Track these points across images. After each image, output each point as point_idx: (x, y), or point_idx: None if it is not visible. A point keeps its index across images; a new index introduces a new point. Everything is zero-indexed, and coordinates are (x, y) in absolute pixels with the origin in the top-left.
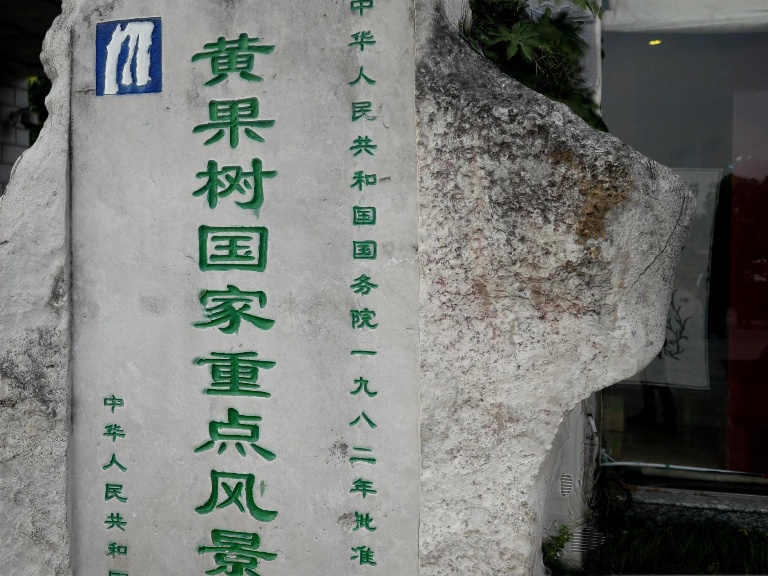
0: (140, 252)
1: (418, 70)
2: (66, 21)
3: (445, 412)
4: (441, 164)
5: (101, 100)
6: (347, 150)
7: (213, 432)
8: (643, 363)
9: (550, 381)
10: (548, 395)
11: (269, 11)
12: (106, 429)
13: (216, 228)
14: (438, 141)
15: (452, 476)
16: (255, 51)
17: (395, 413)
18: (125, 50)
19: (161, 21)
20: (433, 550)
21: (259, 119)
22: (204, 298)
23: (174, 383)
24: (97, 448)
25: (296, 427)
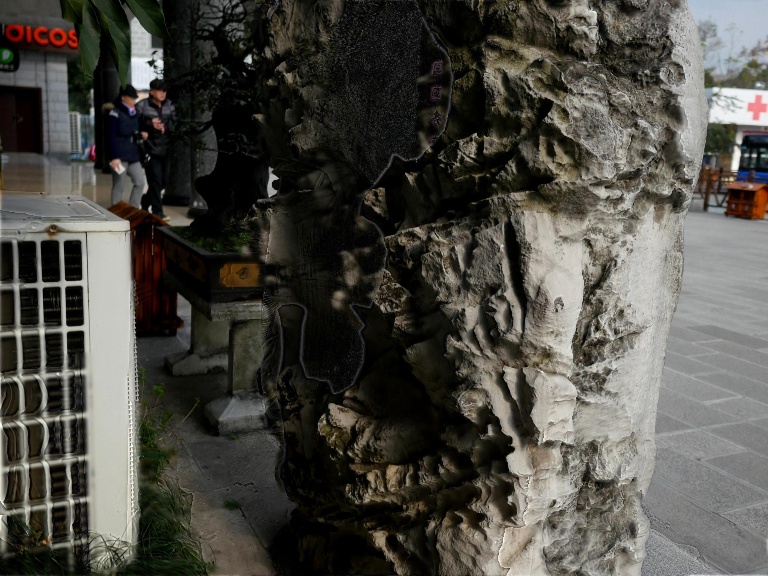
0: None
1: None
2: None
3: None
4: None
5: None
6: None
7: None
8: (352, 161)
9: None
10: None
11: None
12: None
13: None
14: None
15: None
16: None
17: None
18: None
19: None
20: None
21: None
22: None
23: None
24: None
25: None
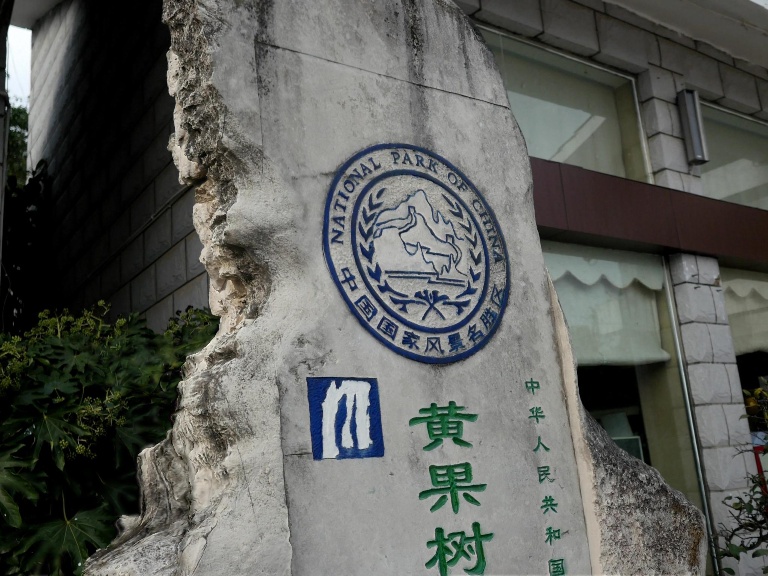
0: None
1: (589, 443)
2: (263, 370)
3: None
4: (612, 518)
5: (319, 465)
6: (540, 509)
7: None
8: None
9: None
10: None
11: (470, 383)
12: None
13: None
14: (608, 500)
15: None
16: (461, 418)
17: None
18: (342, 410)
19: (377, 383)
20: None
21: (474, 484)
22: None
23: None
24: None
25: None
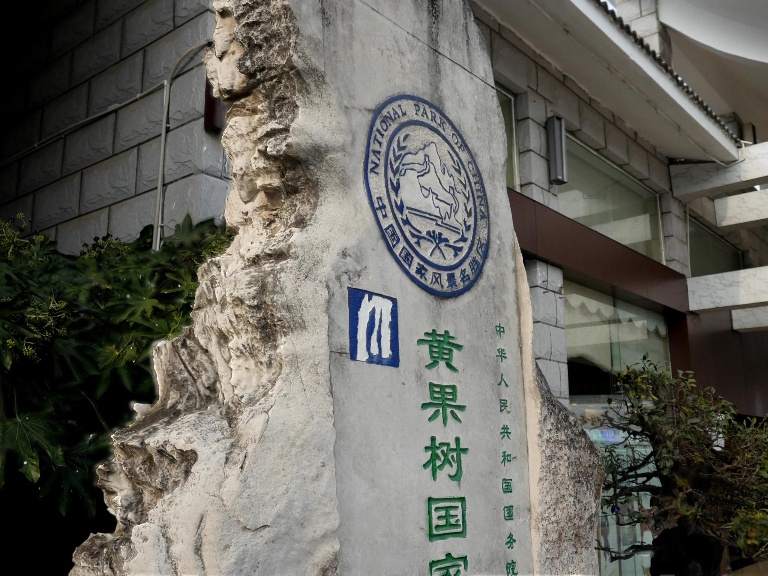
0: (389, 528)
1: None
2: (315, 273)
3: None
4: (549, 450)
5: (354, 365)
6: (499, 435)
7: None
8: None
9: None
10: None
11: (459, 318)
12: None
13: (438, 499)
14: (548, 434)
15: None
16: (451, 347)
17: None
18: (372, 321)
19: (397, 303)
20: None
21: (458, 404)
22: (431, 569)
23: None
24: None
25: None
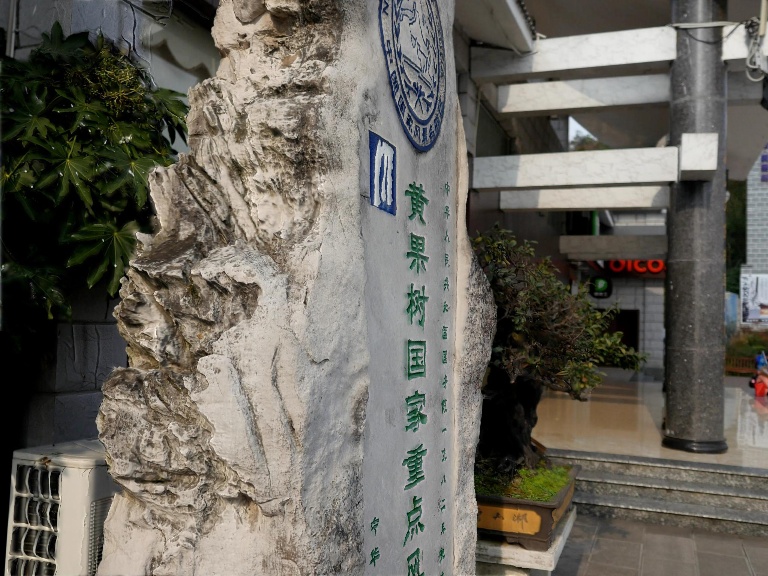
0: (389, 366)
1: None
2: (348, 112)
3: None
4: None
5: (372, 210)
6: None
7: None
8: None
9: None
10: None
11: None
12: (371, 556)
13: (413, 342)
14: None
15: None
16: None
17: None
18: None
19: (396, 151)
20: (462, 553)
21: (425, 255)
22: None
23: (394, 488)
24: None
25: (430, 497)
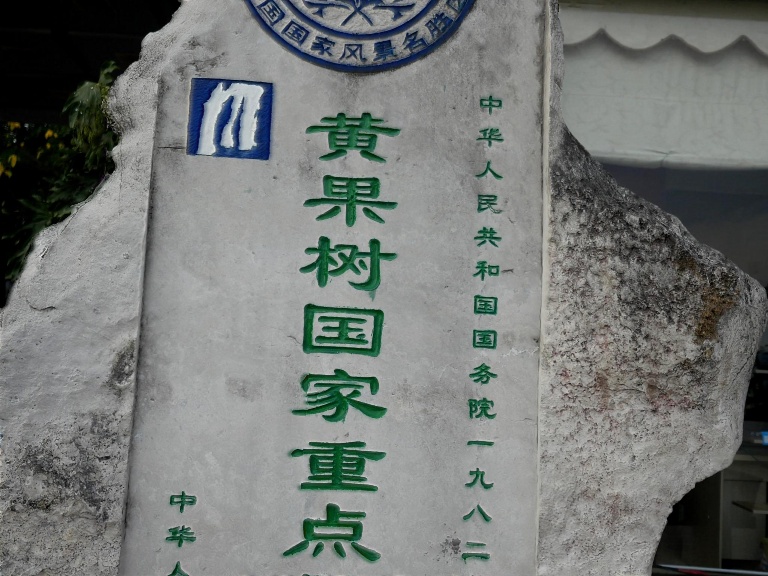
0: (231, 329)
1: (554, 173)
2: (149, 70)
3: (564, 502)
4: (573, 262)
5: (192, 160)
6: (471, 240)
7: (307, 531)
8: None
9: (663, 470)
10: (661, 484)
11: (395, 96)
12: (170, 532)
13: (325, 308)
14: (571, 240)
15: (570, 567)
16: (377, 132)
17: (510, 505)
18: (226, 111)
19: (272, 87)
20: None
21: (380, 200)
22: (306, 382)
23: (261, 476)
24: (156, 555)
25: (405, 522)
